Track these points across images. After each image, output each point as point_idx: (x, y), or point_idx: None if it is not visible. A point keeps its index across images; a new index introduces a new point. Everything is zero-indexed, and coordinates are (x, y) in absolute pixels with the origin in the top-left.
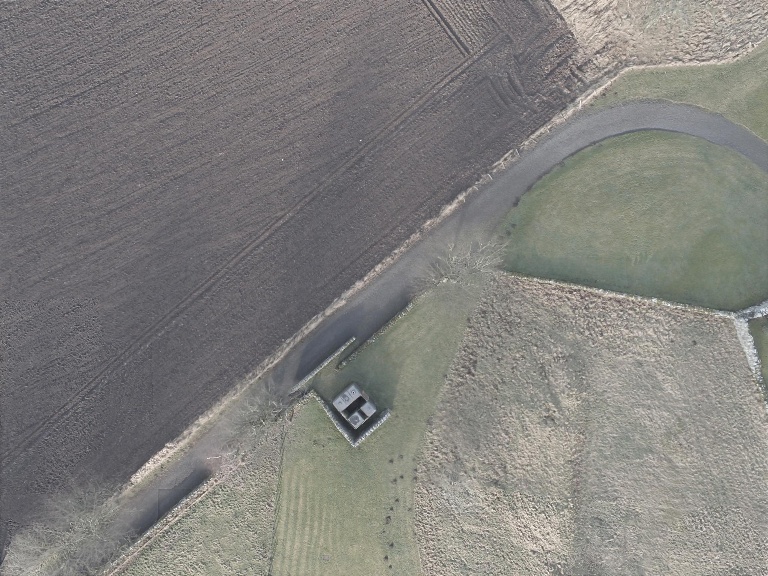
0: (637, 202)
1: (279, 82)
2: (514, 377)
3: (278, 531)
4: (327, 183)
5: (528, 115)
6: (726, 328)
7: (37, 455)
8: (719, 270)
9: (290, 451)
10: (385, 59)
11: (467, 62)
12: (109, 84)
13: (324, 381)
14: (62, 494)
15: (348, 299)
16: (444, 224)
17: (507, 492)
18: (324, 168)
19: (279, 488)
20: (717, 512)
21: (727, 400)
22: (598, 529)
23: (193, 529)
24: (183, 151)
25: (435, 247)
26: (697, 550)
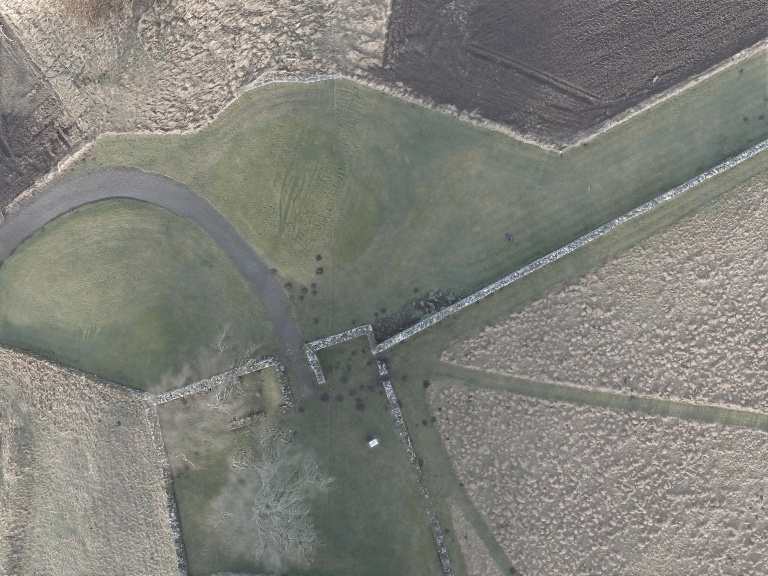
0: (95, 273)
1: None
2: None
3: None
4: None
5: (14, 177)
6: None
7: None
8: (150, 349)
9: None
10: None
11: None
12: None
13: None
14: None
15: None
16: None
17: None
18: None
19: None
20: None
21: (137, 485)
22: None
23: None
24: None
25: None
26: None
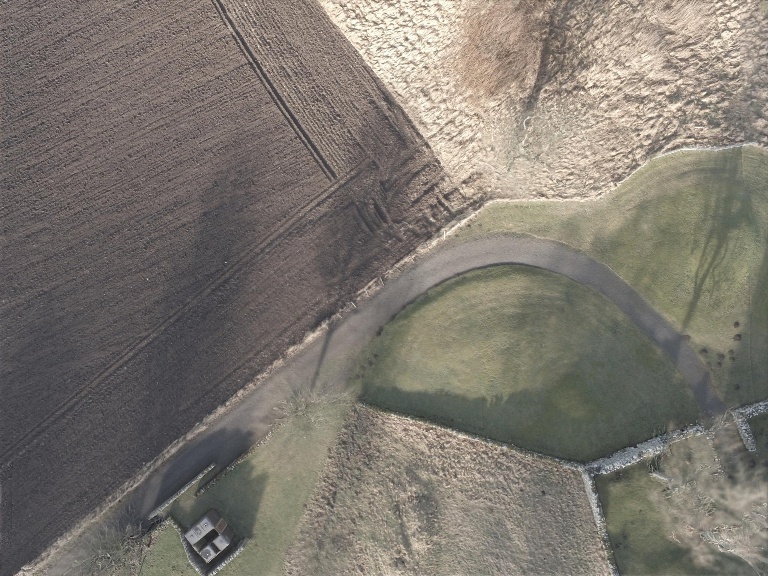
0: (495, 341)
1: (145, 200)
2: (371, 512)
3: None
4: (192, 304)
5: (393, 243)
6: (574, 480)
7: None
8: (571, 418)
9: None
10: (251, 181)
11: (333, 187)
12: None
13: (183, 507)
14: None
15: (210, 424)
16: (307, 351)
17: None
18: (189, 289)
19: None
20: None
21: (572, 555)
22: None
23: None
24: (48, 267)
25: (298, 374)
26: None
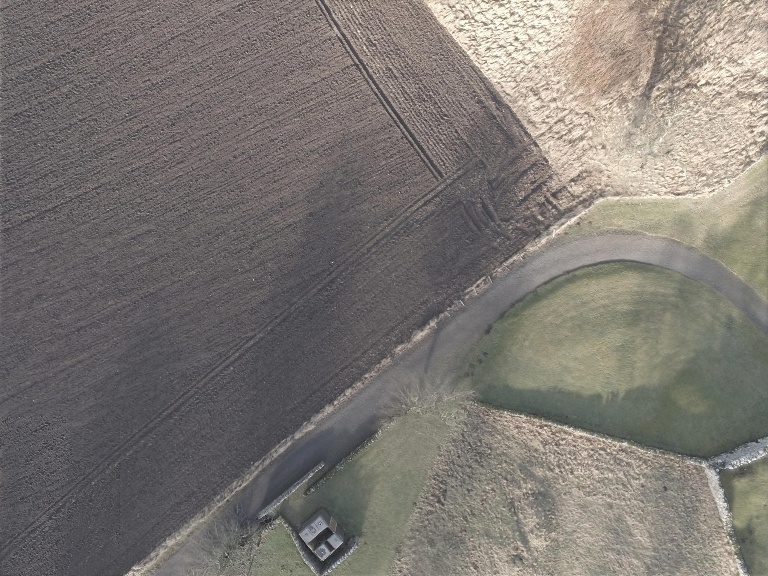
0: (610, 337)
1: (251, 201)
2: (483, 510)
3: None
4: (298, 304)
5: (501, 241)
6: (697, 475)
7: (3, 574)
8: (691, 414)
9: (257, 575)
10: (358, 181)
11: (440, 186)
12: (81, 199)
13: (292, 506)
14: None
15: (318, 423)
16: (415, 349)
17: None
18: (295, 289)
19: None
20: None
21: (697, 551)
22: None
23: None
24: (154, 269)
25: (406, 372)
26: None
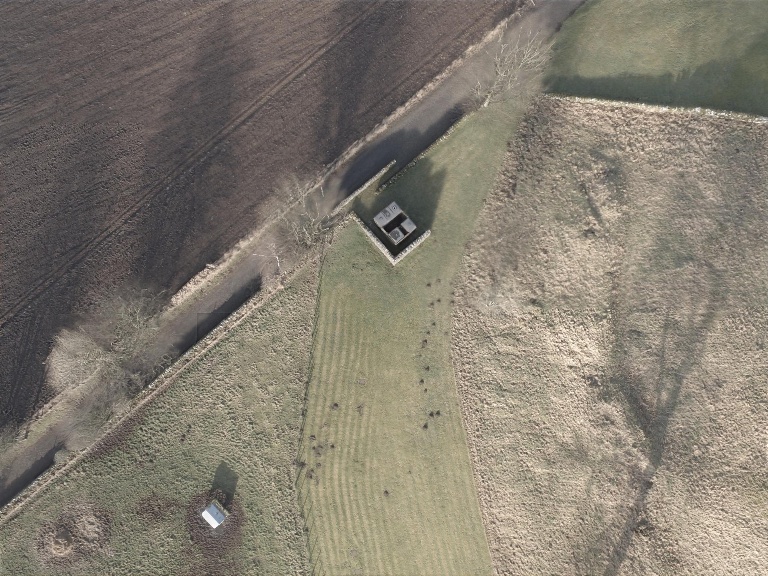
0: (680, 20)
1: None
2: (554, 197)
3: (315, 355)
4: (370, 12)
5: None
6: None
7: (80, 276)
8: (763, 80)
9: (329, 275)
10: None
11: None
12: None
13: (364, 204)
14: (103, 315)
15: (389, 125)
16: (486, 50)
17: (545, 310)
18: None
19: (317, 312)
20: (758, 312)
21: None
22: (636, 341)
23: (231, 353)
24: None
25: (476, 73)
26: (737, 350)
